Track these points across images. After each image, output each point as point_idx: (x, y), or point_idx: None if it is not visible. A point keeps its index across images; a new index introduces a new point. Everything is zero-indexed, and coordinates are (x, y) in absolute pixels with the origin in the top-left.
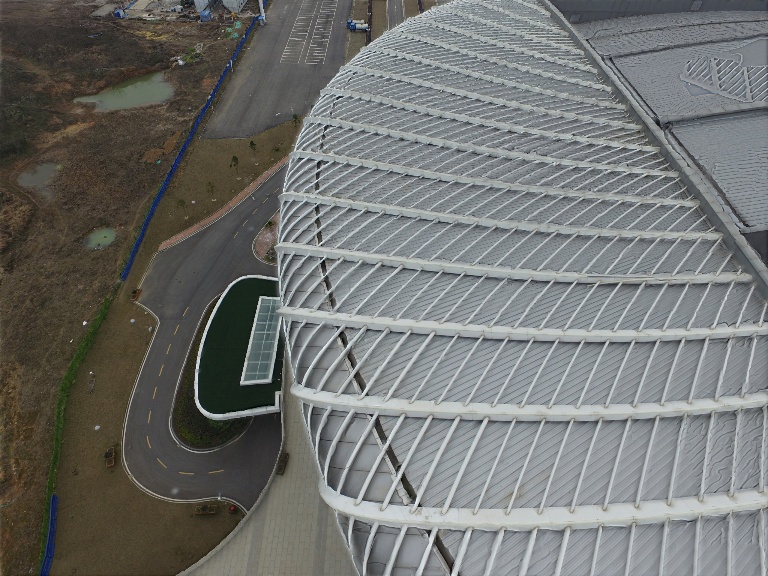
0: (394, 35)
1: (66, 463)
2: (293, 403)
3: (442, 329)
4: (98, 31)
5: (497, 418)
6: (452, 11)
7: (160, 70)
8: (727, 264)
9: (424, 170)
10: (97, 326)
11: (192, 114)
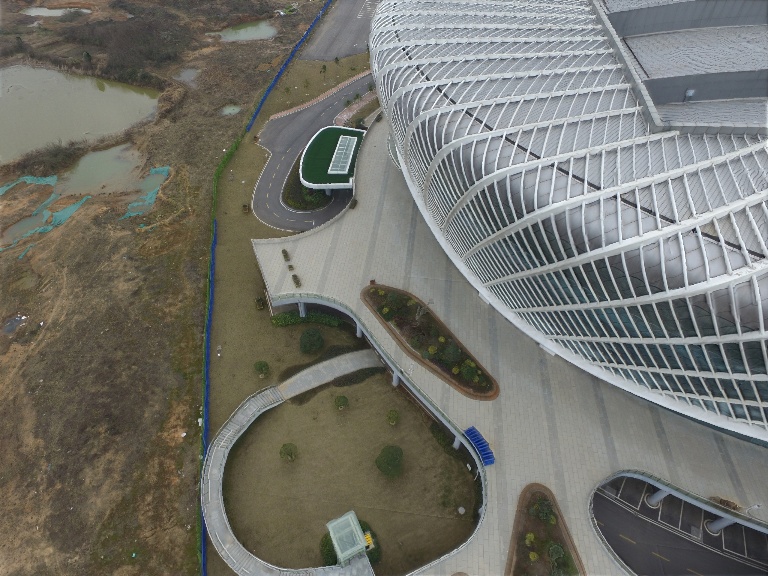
0: None
1: (220, 209)
2: (361, 182)
3: (450, 39)
4: None
5: (469, 58)
6: None
7: (266, 19)
8: (593, 23)
9: None
10: (233, 151)
11: (291, 45)
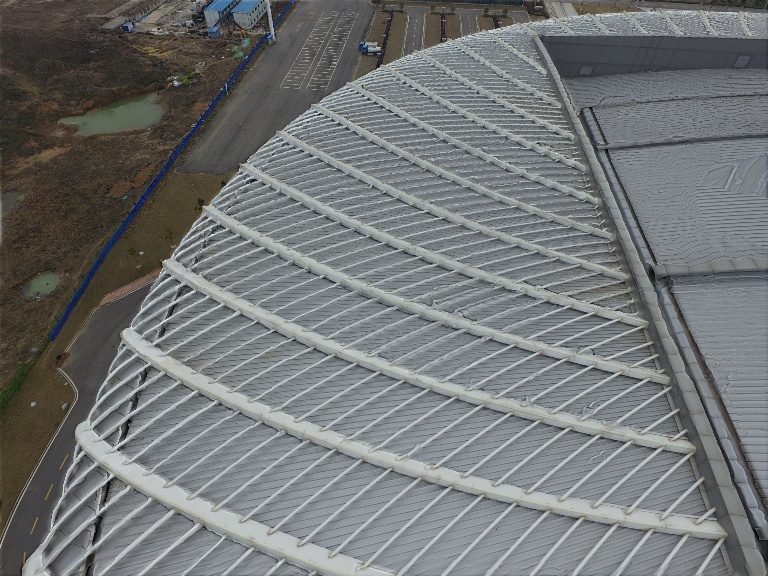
0: (352, 90)
1: None
2: None
3: None
4: (102, 45)
5: None
6: (430, 61)
7: (154, 90)
8: None
9: (299, 327)
10: (7, 398)
11: (174, 143)
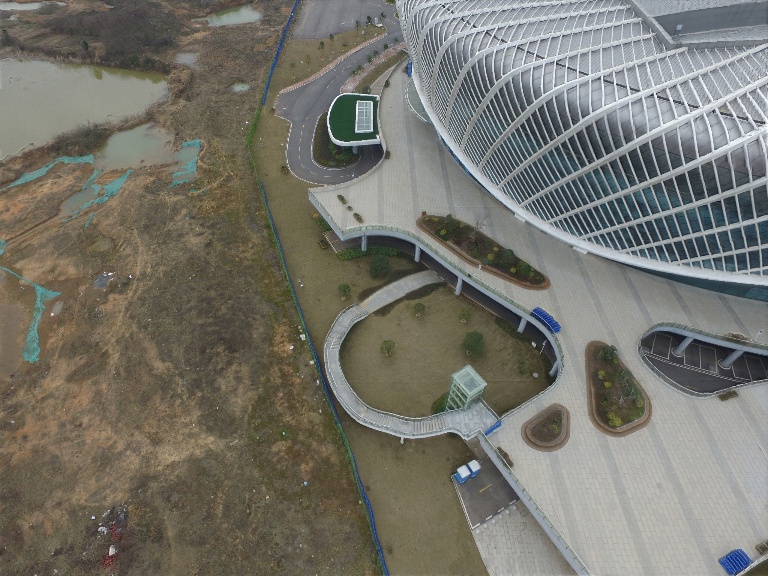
0: None
1: (260, 172)
2: (388, 137)
3: None
4: None
5: (506, 8)
6: None
7: (246, 4)
8: None
9: None
10: None
11: (280, 27)
